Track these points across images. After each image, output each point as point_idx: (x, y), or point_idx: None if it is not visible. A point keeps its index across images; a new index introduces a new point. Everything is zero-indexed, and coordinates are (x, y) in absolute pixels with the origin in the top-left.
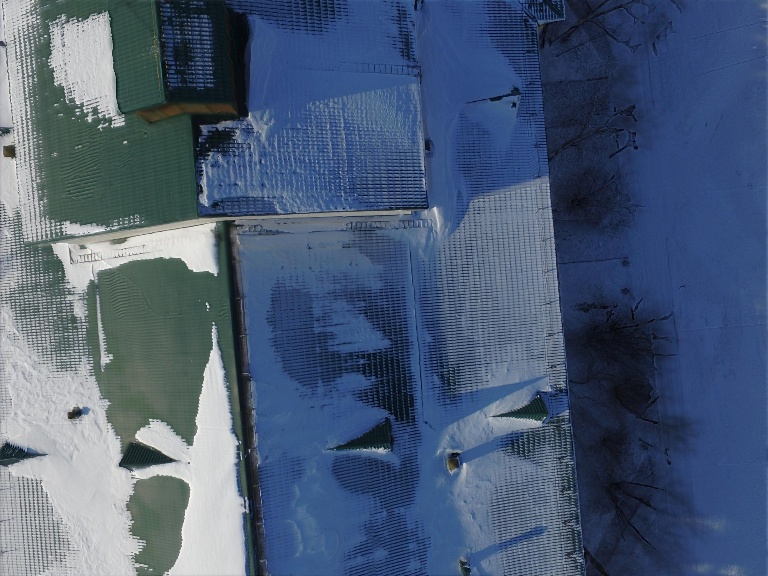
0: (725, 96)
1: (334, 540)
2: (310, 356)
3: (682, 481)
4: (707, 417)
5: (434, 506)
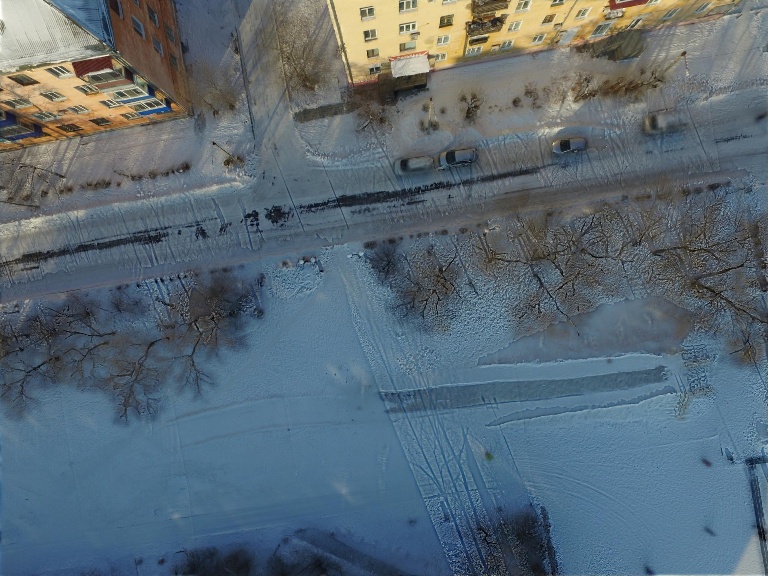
0: (3, 486)
1: None
2: None
3: (312, 505)
4: (259, 486)
5: None
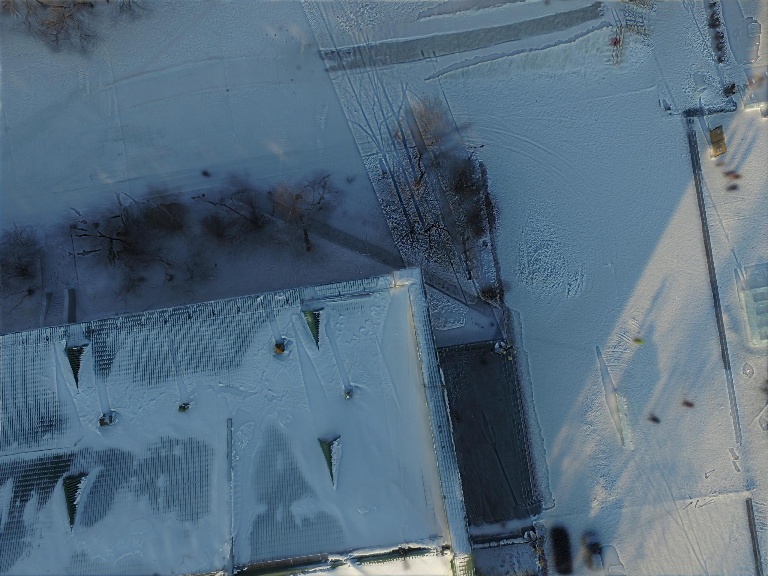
0: None
1: (138, 524)
2: (2, 549)
3: (250, 166)
4: (196, 149)
5: (139, 435)
